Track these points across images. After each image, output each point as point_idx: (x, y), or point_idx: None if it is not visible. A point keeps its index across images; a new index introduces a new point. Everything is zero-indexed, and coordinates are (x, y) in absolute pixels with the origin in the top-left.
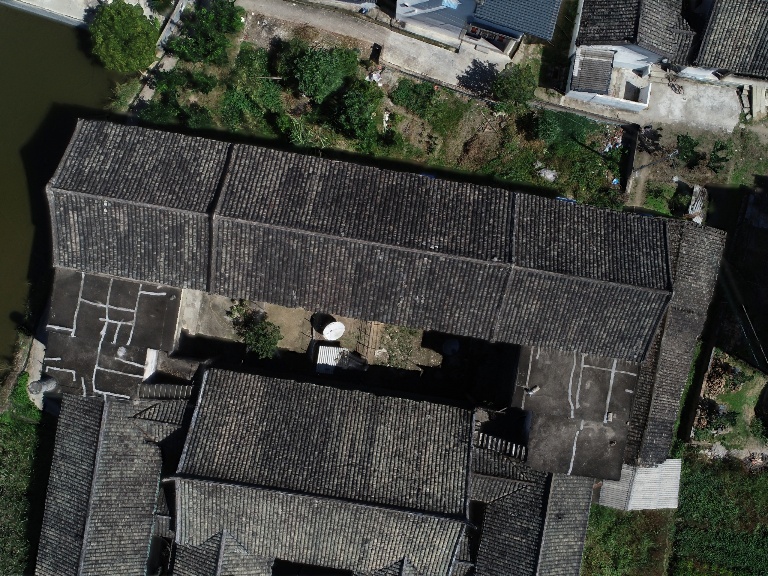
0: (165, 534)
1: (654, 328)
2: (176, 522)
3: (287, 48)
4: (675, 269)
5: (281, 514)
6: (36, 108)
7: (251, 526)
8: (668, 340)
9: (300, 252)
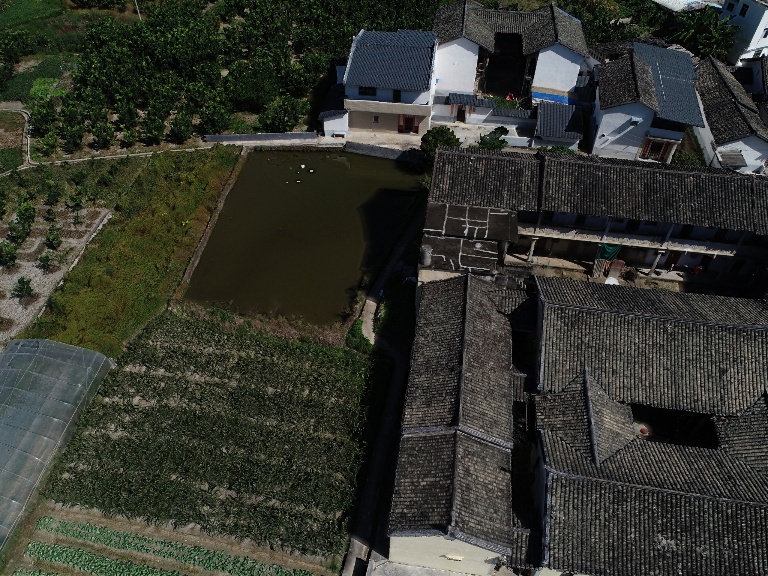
0: (519, 397)
1: None
2: (540, 361)
3: None
4: None
5: (638, 345)
6: (367, 192)
7: (611, 362)
8: None
9: (604, 179)
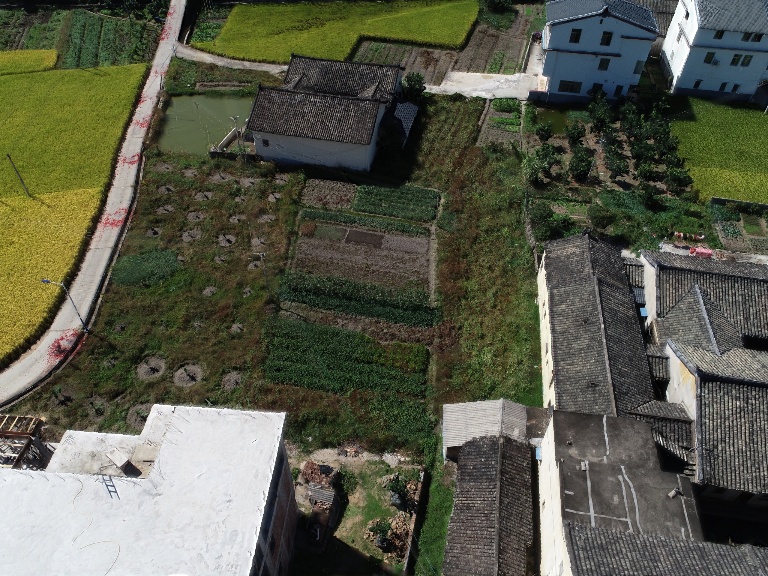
0: None
1: (575, 558)
2: None
3: None
4: None
5: None
6: None
7: None
8: (487, 569)
9: None
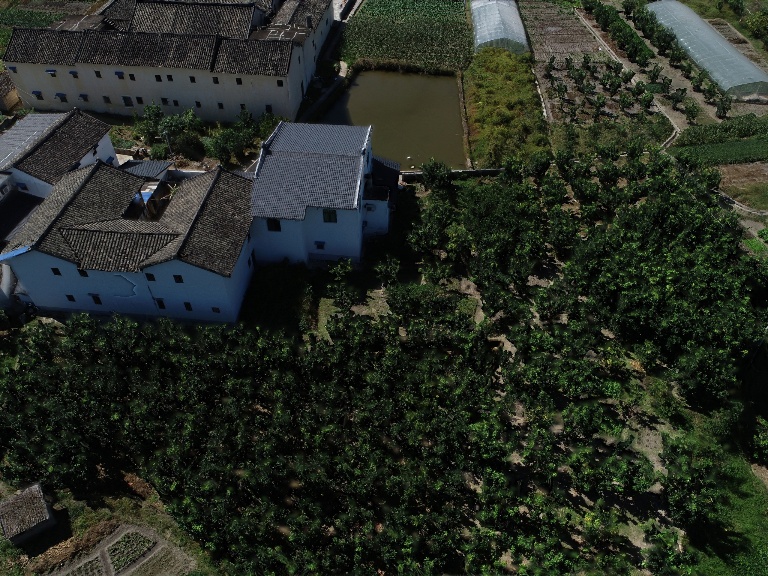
0: None
1: None
2: None
3: (190, 145)
4: (4, 80)
5: None
6: None
7: None
8: None
9: None
